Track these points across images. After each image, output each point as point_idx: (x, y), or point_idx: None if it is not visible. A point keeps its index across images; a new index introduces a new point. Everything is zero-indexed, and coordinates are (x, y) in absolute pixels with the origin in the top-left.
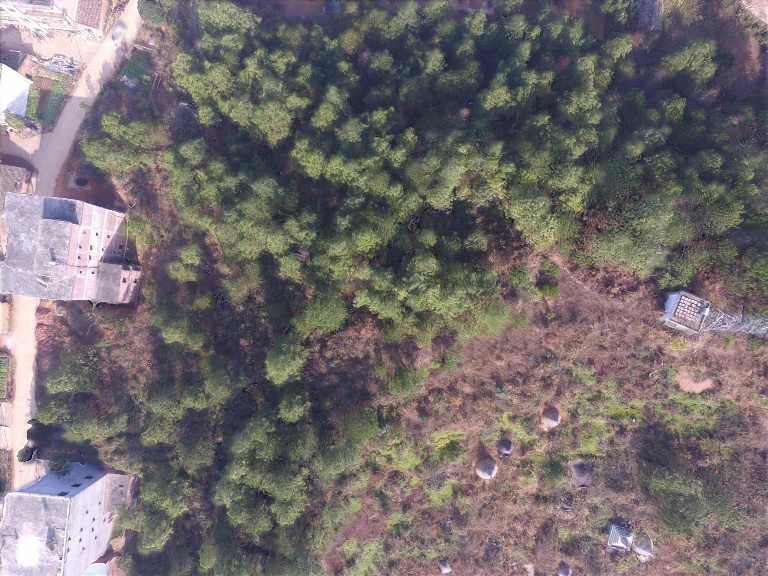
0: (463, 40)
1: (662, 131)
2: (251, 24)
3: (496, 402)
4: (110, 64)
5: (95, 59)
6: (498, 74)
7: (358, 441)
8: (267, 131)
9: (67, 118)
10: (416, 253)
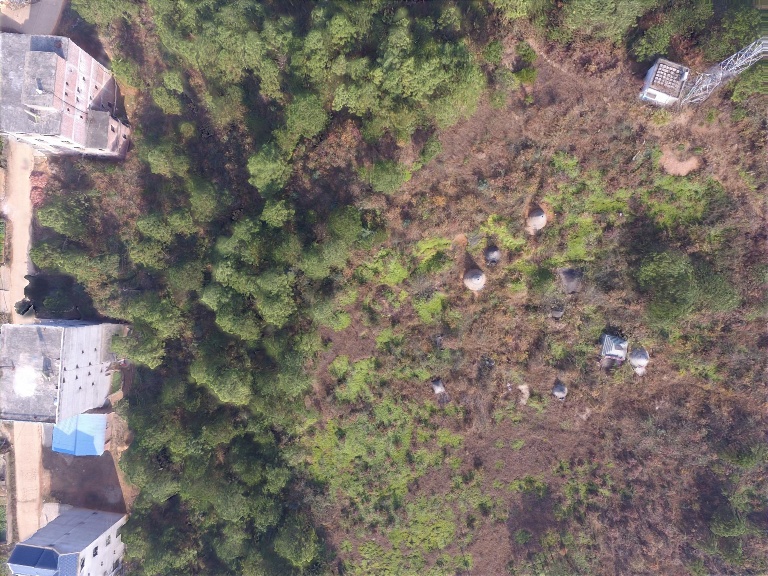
0: None
1: None
2: None
3: (480, 202)
4: None
5: None
6: None
7: (341, 237)
8: None
9: None
10: (389, 33)
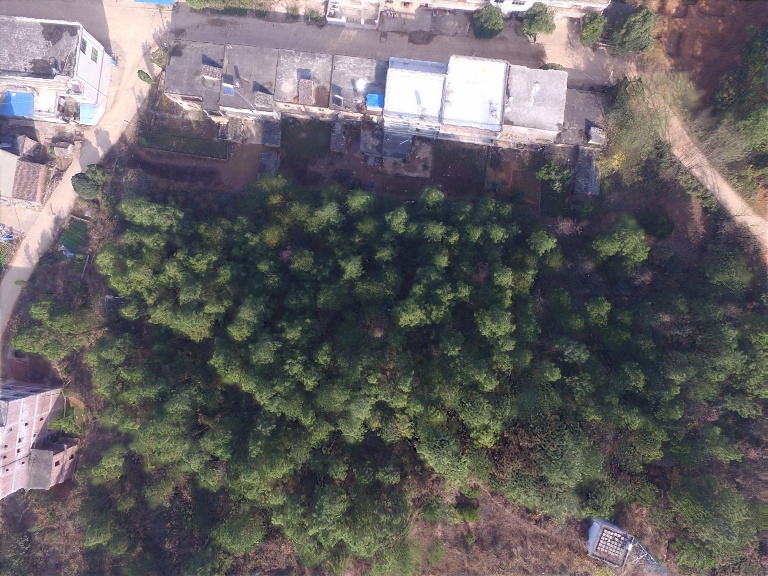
0: (383, 239)
1: (585, 340)
2: (173, 221)
3: None
4: (48, 233)
5: (34, 229)
6: (414, 285)
7: None
8: (188, 333)
9: (6, 288)
10: (326, 489)
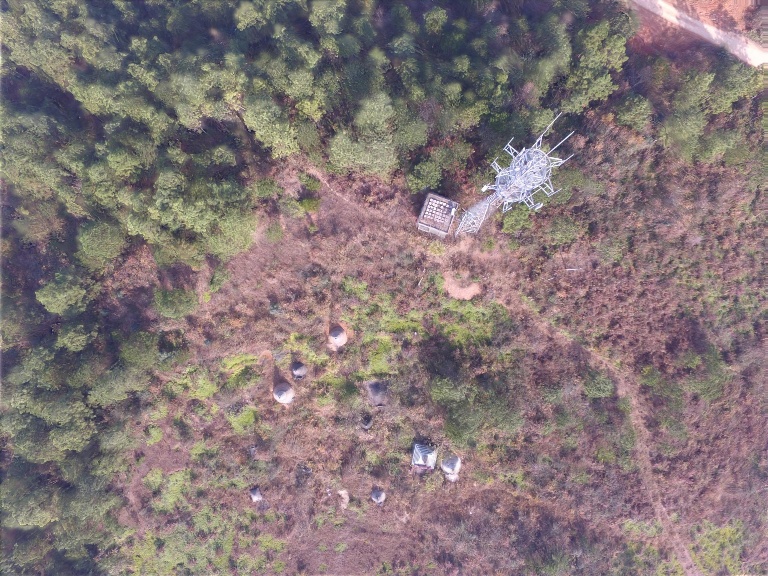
0: None
1: (421, 43)
2: None
3: (277, 322)
4: None
5: None
6: None
7: (134, 364)
8: (50, 73)
9: None
10: (164, 171)
